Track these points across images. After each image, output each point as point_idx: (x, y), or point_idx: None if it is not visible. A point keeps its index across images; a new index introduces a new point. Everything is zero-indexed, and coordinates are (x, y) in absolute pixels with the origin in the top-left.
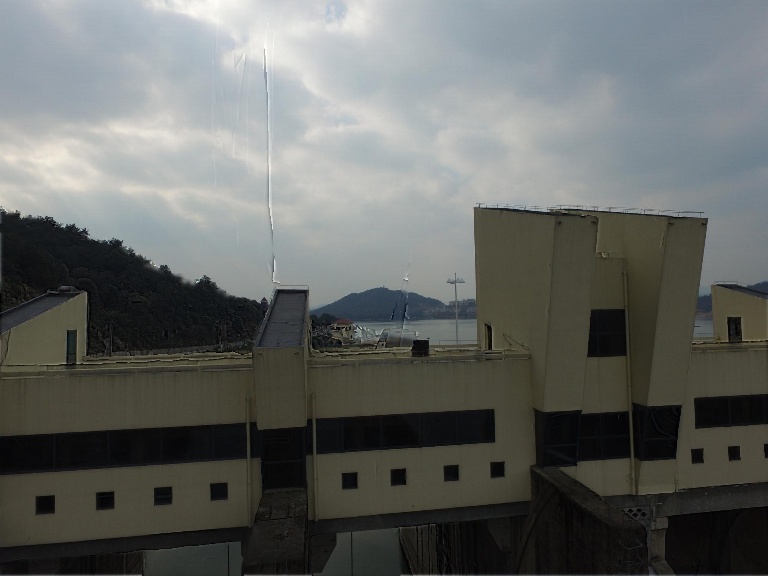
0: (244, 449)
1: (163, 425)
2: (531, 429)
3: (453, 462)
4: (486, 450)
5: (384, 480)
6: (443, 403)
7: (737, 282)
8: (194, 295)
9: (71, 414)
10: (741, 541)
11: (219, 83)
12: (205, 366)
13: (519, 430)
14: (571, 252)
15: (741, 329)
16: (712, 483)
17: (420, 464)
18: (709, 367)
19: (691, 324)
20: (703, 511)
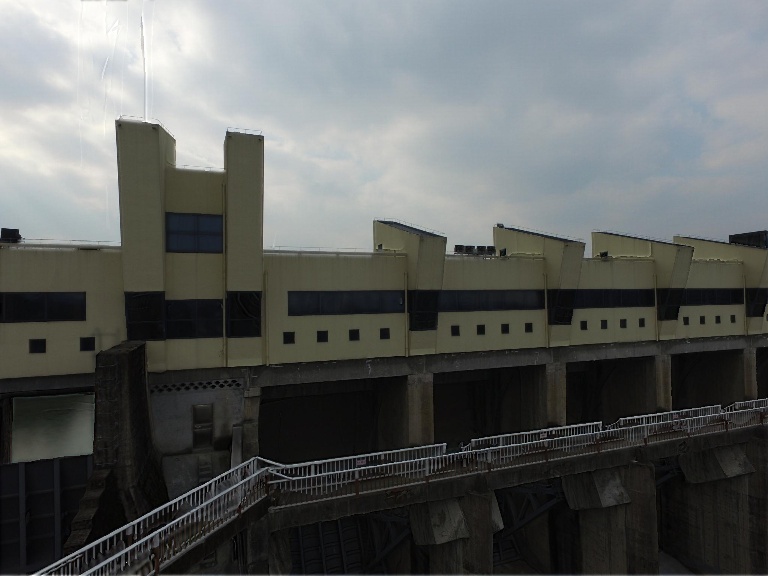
0: None
1: None
2: (124, 310)
3: (40, 336)
4: (76, 327)
5: None
6: (31, 284)
7: None
8: None
9: None
10: (381, 426)
11: (88, 49)
12: None
13: (111, 310)
14: (137, 152)
15: None
16: (301, 360)
17: (3, 337)
18: (303, 267)
19: (261, 223)
20: (295, 383)
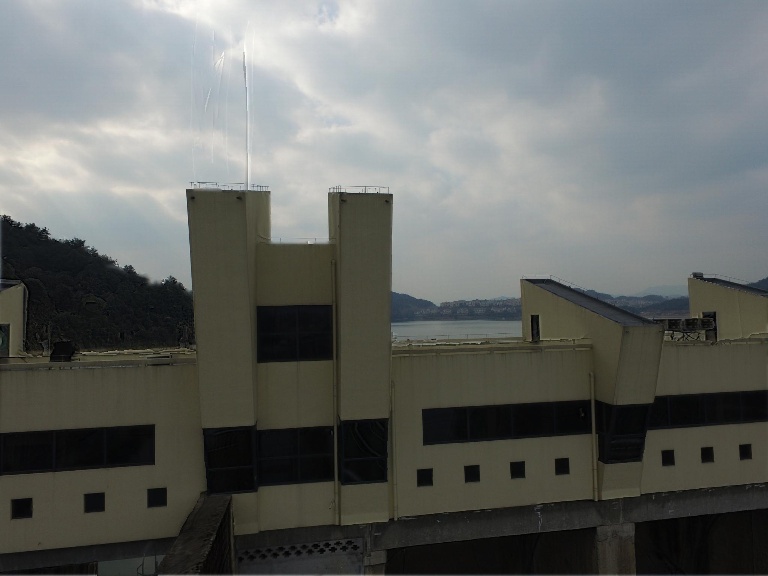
0: None
1: None
2: (203, 448)
3: (97, 489)
4: (143, 474)
5: (2, 512)
6: (86, 418)
7: (550, 276)
8: (156, 296)
9: None
10: (540, 568)
11: (199, 82)
12: None
13: (187, 450)
14: (216, 234)
15: (539, 329)
16: (443, 509)
17: (52, 492)
18: (443, 373)
19: (387, 322)
20: (434, 542)
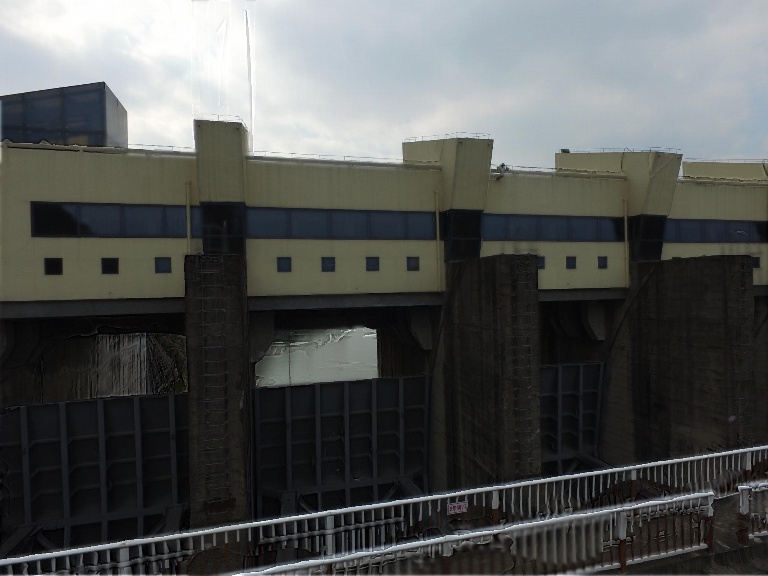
0: (763, 239)
1: (729, 218)
2: None
3: None
4: None
5: None
6: None
7: None
8: None
9: (686, 207)
10: None
11: (196, 48)
12: (748, 183)
13: None
14: None
15: None
16: None
17: None
18: None
19: None
20: None
